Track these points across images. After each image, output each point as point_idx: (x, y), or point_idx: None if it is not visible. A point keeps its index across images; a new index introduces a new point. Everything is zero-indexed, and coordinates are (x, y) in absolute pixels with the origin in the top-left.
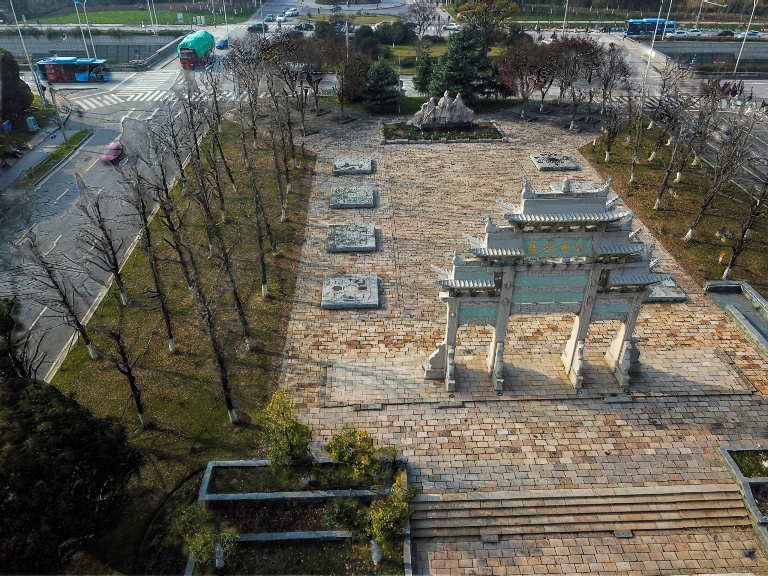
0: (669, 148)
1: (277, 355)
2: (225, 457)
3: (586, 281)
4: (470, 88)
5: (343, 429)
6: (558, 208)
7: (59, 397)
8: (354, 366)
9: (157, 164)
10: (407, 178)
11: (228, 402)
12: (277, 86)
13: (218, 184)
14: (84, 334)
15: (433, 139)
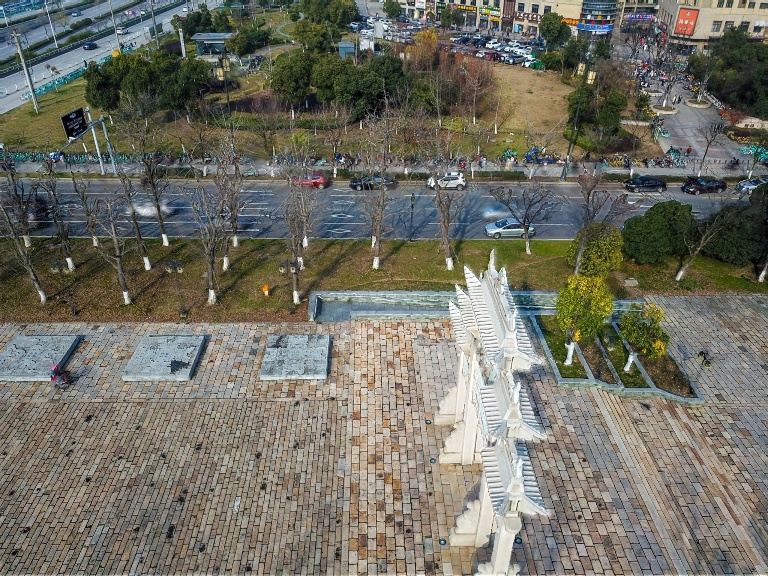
0: None
1: None
2: None
3: None
4: None
5: None
6: None
7: None
8: None
9: None
10: None
11: None
12: None
13: None
14: None
15: None
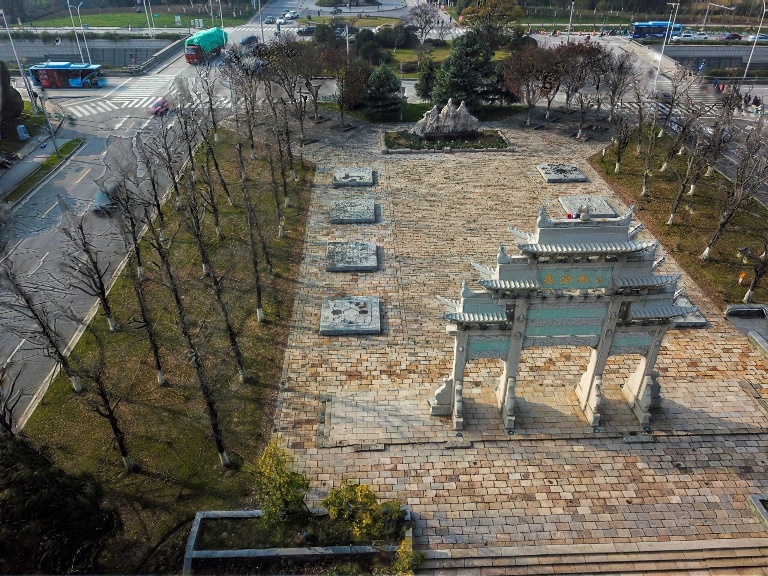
0: (681, 158)
1: (272, 387)
2: (215, 505)
3: (605, 313)
4: (474, 95)
5: (342, 483)
6: (576, 237)
7: (28, 454)
8: (354, 400)
9: (148, 179)
10: (410, 190)
11: (218, 444)
12: (276, 92)
13: (212, 199)
14: (66, 366)
15: (436, 148)
